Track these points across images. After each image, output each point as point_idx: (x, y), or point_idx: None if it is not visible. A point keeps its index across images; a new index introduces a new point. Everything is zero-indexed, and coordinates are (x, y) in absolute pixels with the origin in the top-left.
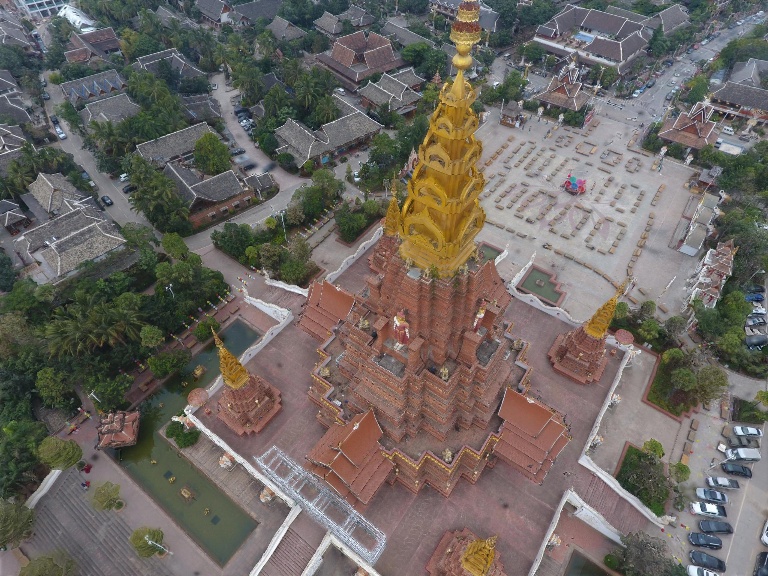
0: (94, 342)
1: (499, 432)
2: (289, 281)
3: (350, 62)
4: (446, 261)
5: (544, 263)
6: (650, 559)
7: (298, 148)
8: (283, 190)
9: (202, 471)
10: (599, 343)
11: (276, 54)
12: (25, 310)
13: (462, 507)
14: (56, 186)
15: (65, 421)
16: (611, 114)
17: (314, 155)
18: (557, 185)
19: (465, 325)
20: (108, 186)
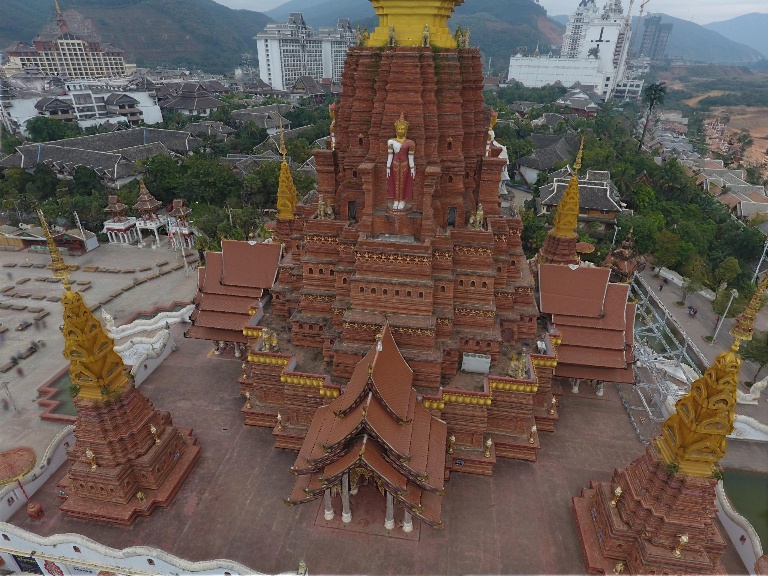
0: None
1: None
2: None
3: None
4: None
5: None
6: None
7: None
8: None
9: None
10: None
11: None
12: None
13: None
14: None
15: None
16: None
17: None
18: None
19: None
20: None
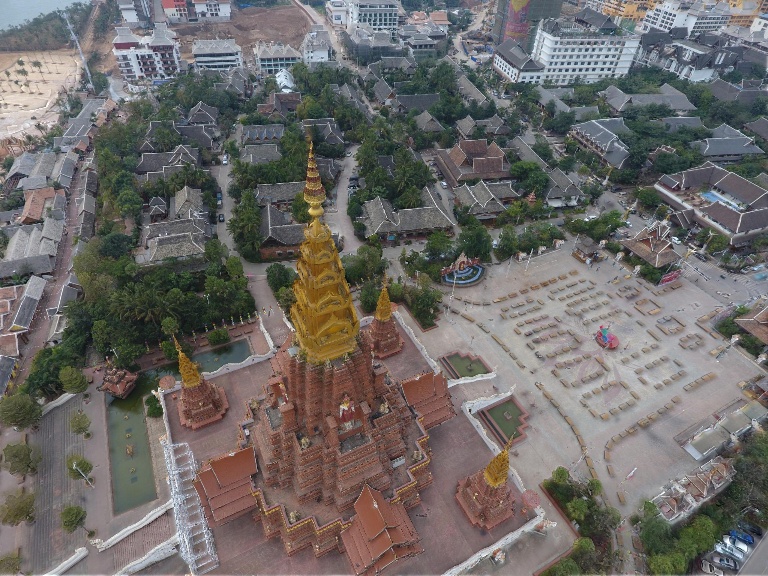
0: (136, 315)
1: None
2: None
3: (460, 163)
4: (317, 351)
5: (525, 399)
6: None
7: (372, 222)
8: (345, 251)
9: (149, 440)
10: (493, 490)
11: (407, 141)
12: (116, 276)
13: (295, 571)
14: (189, 198)
15: (98, 362)
16: (702, 282)
17: (381, 231)
18: (590, 331)
19: (332, 410)
20: (229, 207)
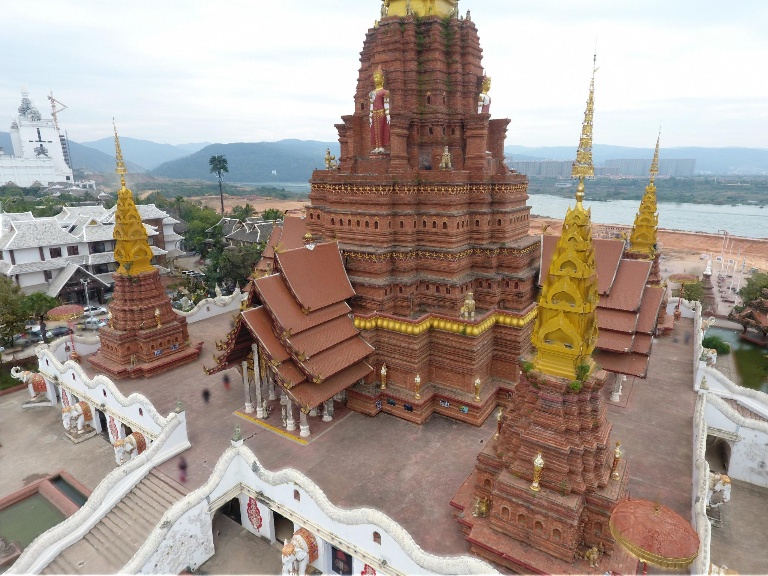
0: None
1: None
2: None
3: None
4: None
5: None
6: (236, 265)
7: None
8: None
9: None
10: None
11: None
12: None
13: None
14: None
15: None
16: None
17: None
18: None
19: None
20: None
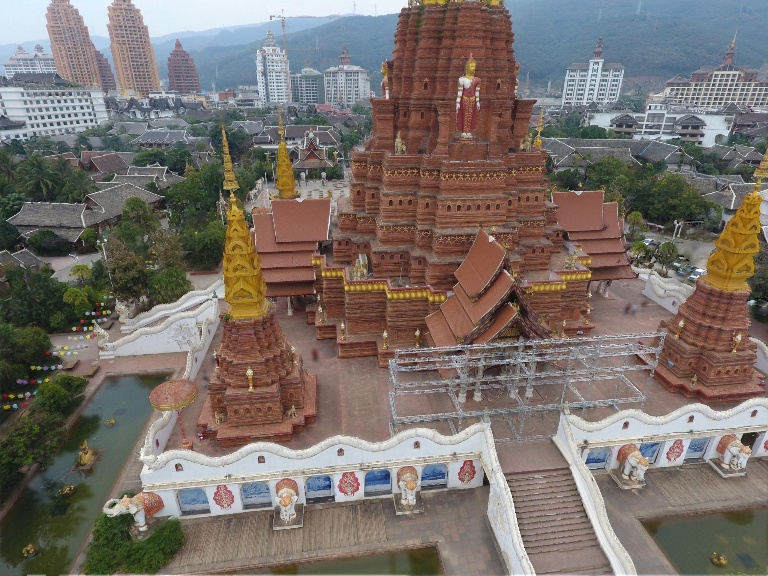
0: None
1: (575, 243)
2: (171, 300)
3: None
4: None
5: None
6: None
7: (60, 224)
8: (61, 269)
9: (244, 568)
10: None
11: None
12: None
13: None
14: None
15: None
16: None
17: (91, 224)
18: None
19: None
20: None
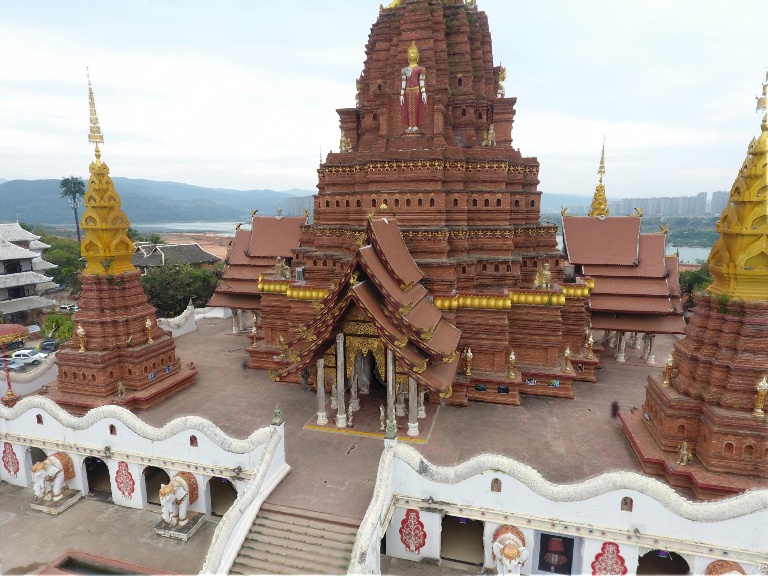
0: None
1: None
2: None
3: None
4: None
5: None
6: None
7: None
8: None
9: None
10: None
11: None
12: None
13: None
14: None
15: None
16: None
17: None
18: None
19: None
20: None
